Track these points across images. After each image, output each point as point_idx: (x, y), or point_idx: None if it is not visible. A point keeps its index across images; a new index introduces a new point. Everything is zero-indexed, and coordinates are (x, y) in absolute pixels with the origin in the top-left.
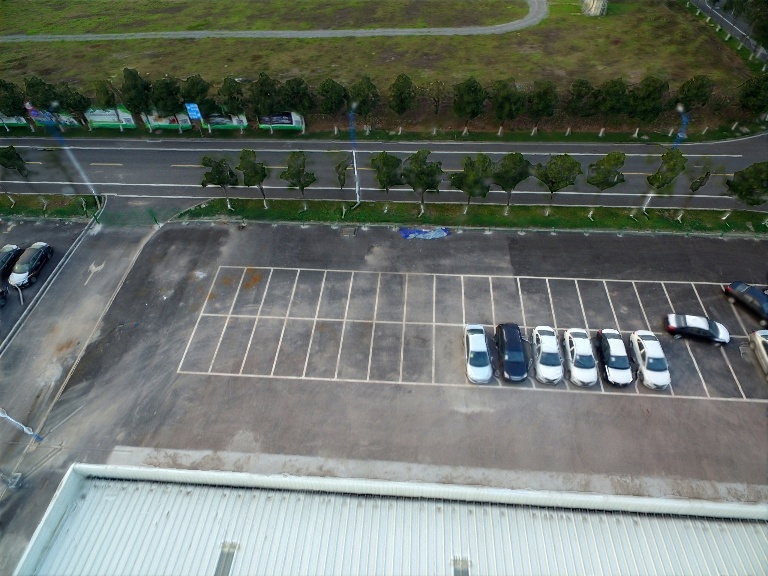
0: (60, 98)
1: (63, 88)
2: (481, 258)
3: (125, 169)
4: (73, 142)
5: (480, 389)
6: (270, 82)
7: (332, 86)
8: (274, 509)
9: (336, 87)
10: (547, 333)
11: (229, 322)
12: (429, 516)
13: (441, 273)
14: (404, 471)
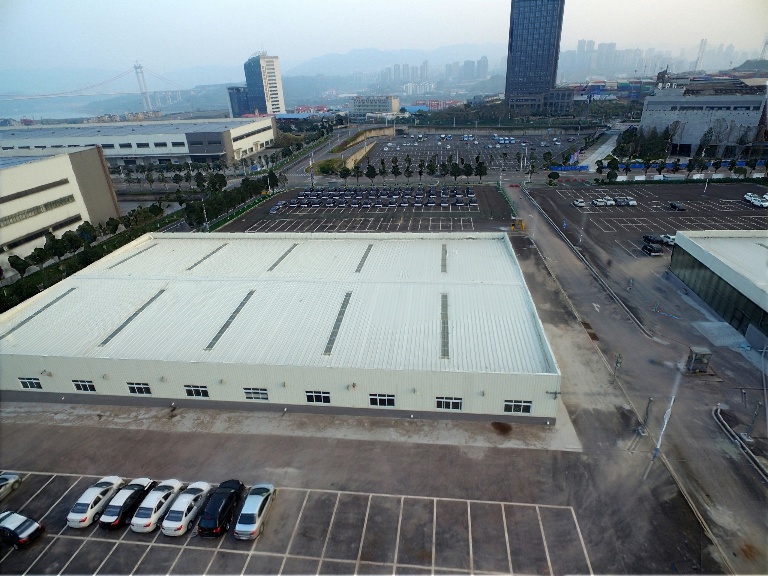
0: None
1: None
2: None
3: None
4: None
5: None
6: None
7: None
8: None
9: None
10: (173, 518)
11: (547, 567)
12: None
13: None
14: (349, 435)
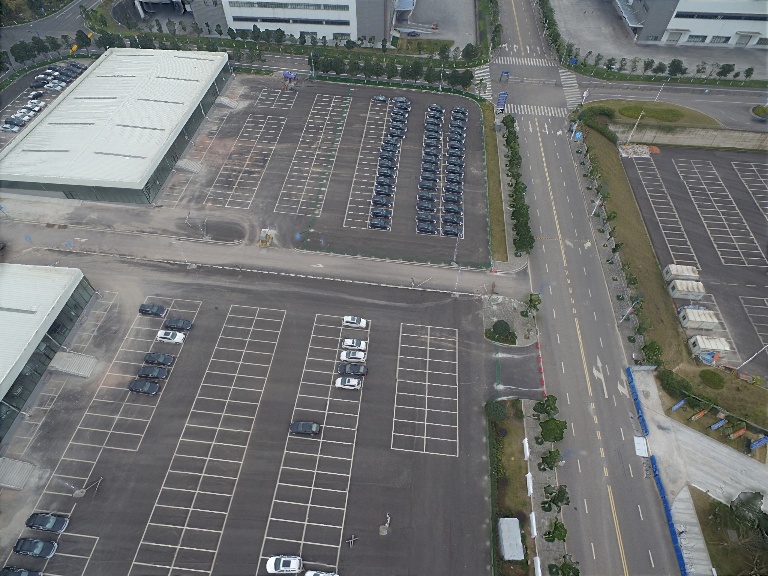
0: None
1: None
2: None
3: None
4: None
5: (21, 131)
6: None
7: None
8: (20, 146)
9: None
10: None
11: None
12: None
13: None
14: None
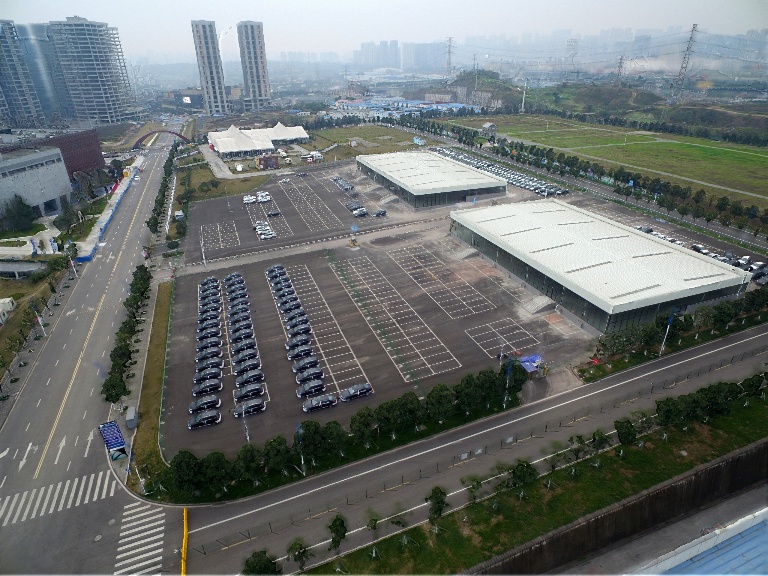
0: (599, 170)
1: (602, 167)
2: (667, 227)
3: (599, 189)
4: (592, 182)
5: None
6: (659, 180)
7: (677, 187)
8: None
9: (678, 187)
10: None
11: None
12: (596, 219)
13: (651, 224)
14: None
